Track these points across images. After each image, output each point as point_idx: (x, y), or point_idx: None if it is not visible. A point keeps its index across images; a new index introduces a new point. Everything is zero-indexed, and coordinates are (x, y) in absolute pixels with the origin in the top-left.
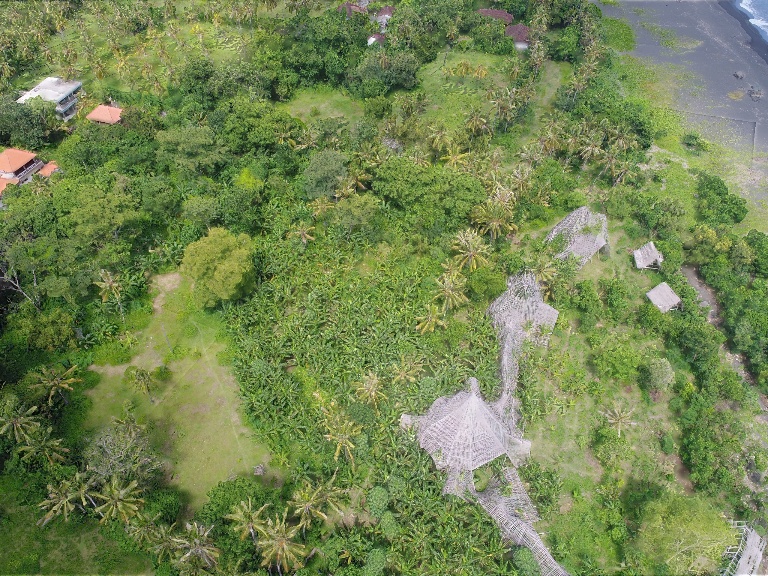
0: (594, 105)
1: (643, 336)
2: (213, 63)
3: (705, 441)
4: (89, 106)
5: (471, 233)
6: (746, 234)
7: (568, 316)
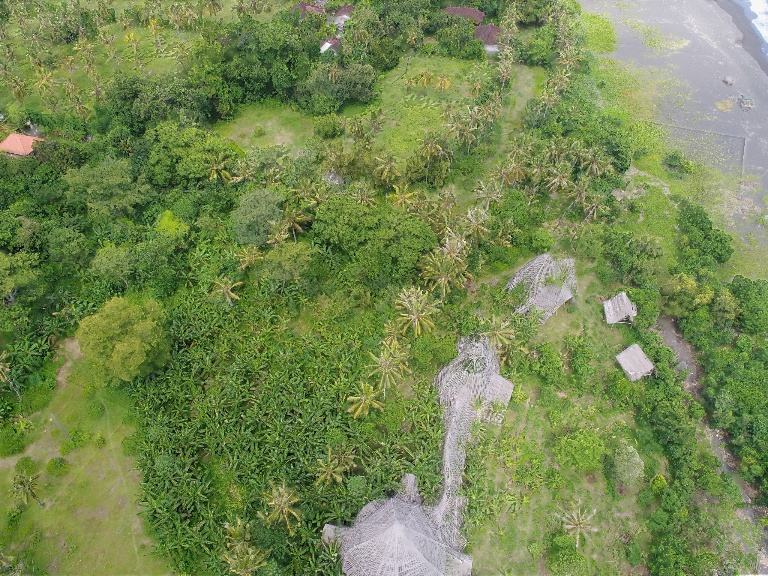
0: (566, 122)
1: (611, 408)
2: (151, 75)
3: (676, 554)
4: (4, 132)
5: (421, 284)
6: (731, 277)
7: (527, 384)
